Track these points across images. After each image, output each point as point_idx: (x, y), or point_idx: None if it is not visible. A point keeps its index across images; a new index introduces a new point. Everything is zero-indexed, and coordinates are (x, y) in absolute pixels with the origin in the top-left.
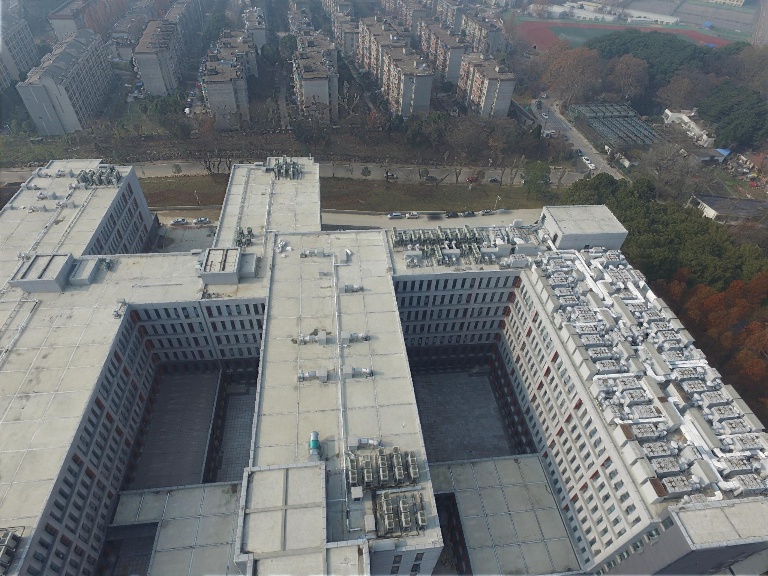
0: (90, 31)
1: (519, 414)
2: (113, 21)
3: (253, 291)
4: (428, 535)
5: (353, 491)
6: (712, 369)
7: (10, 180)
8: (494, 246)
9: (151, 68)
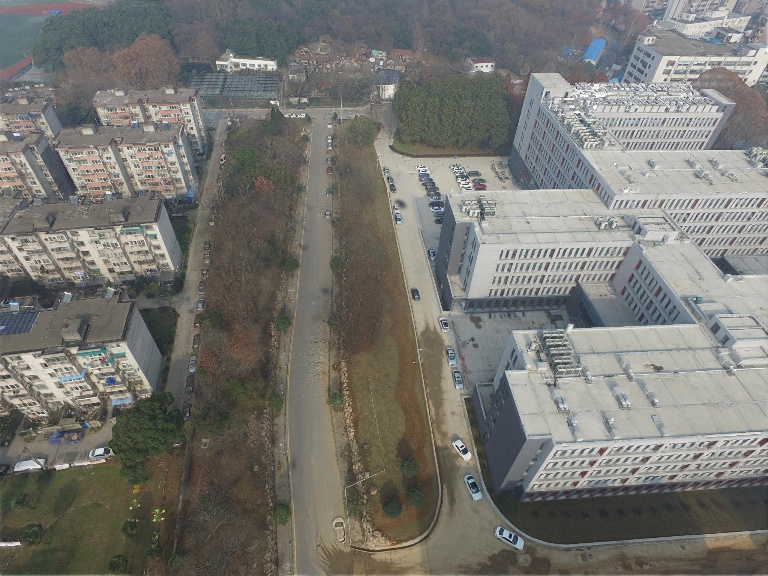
0: None
1: None
2: None
3: None
4: None
5: None
6: (641, 84)
7: None
8: None
9: None
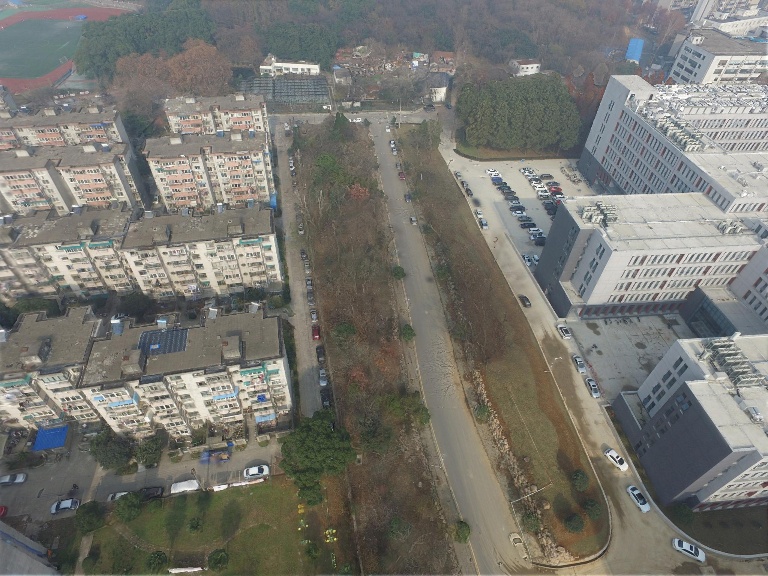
0: None
1: None
2: None
3: None
4: None
5: None
6: (718, 85)
7: None
8: (667, 118)
9: None
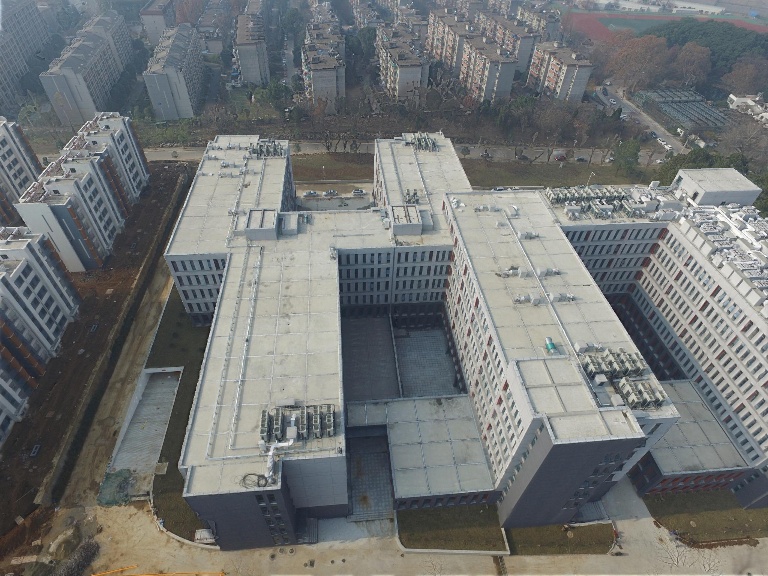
0: (188, 25)
1: (661, 351)
2: (195, 16)
3: (436, 240)
4: (665, 410)
5: (599, 377)
6: None
7: (149, 159)
8: (640, 203)
9: (250, 58)
